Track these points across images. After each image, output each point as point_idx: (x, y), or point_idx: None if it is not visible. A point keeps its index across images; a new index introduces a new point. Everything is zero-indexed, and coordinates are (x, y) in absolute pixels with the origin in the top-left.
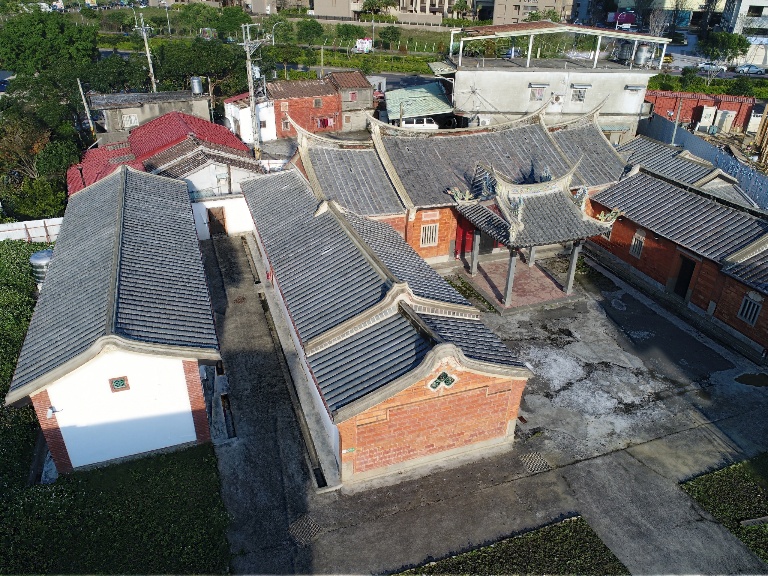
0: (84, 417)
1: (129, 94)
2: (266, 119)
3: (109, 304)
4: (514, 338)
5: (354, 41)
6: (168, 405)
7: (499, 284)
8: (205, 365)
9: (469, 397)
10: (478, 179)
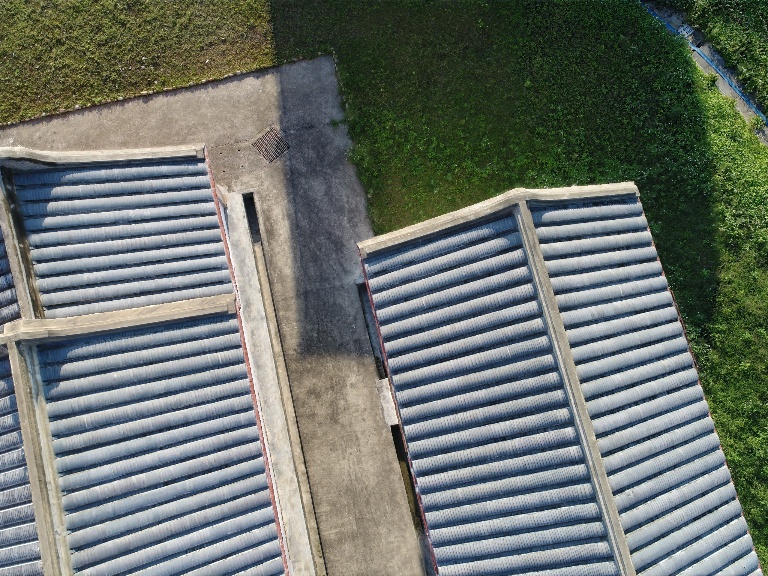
0: None
1: None
2: None
3: None
4: None
5: None
6: None
7: None
8: None
9: None
10: None
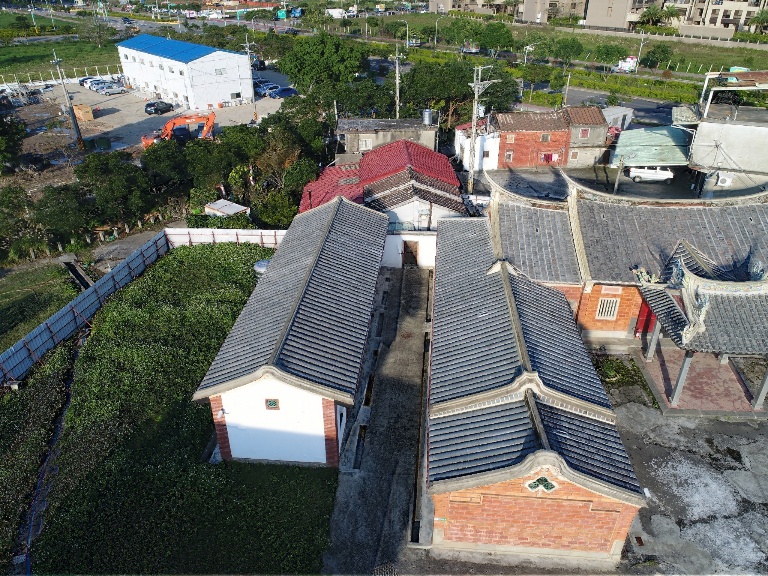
0: (245, 422)
1: (370, 120)
2: (490, 149)
3: (280, 335)
4: (667, 445)
5: (600, 74)
6: (307, 429)
7: (675, 377)
8: (340, 405)
9: (570, 506)
10: (675, 260)
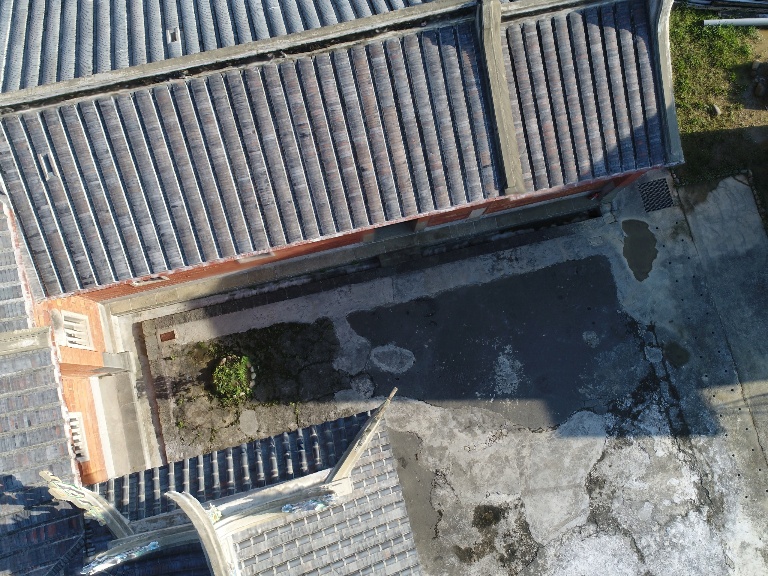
0: None
1: None
2: None
3: None
4: None
5: None
6: None
7: None
8: None
9: None
10: None
